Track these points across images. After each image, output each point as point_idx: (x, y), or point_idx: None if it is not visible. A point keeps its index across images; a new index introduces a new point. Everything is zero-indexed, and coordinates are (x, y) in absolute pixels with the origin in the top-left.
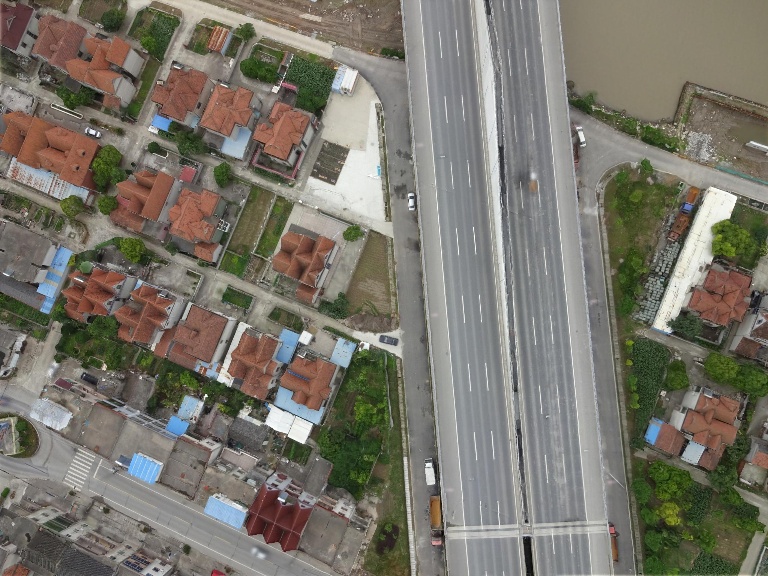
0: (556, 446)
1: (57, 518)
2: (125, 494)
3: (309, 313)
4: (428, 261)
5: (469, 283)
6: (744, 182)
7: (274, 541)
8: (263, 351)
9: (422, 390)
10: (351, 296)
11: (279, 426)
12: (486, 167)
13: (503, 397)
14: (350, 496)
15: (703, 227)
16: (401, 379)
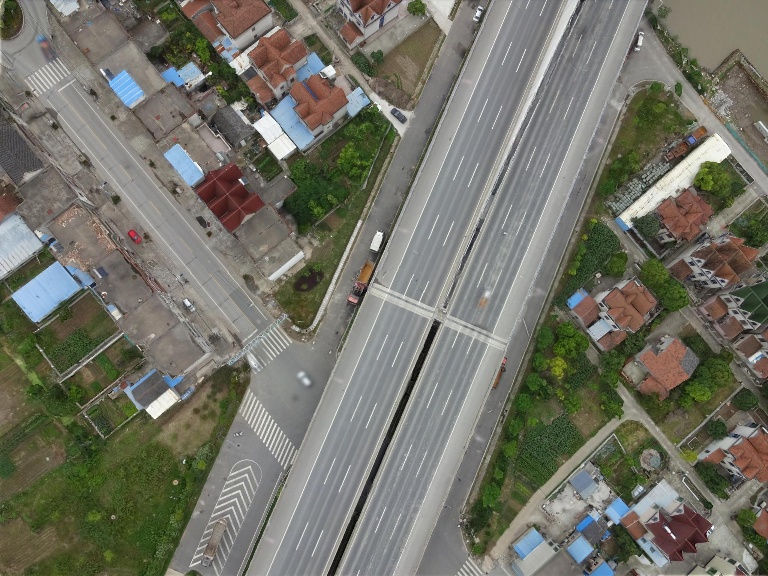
0: (500, 261)
1: (5, 101)
2: (82, 121)
3: (341, 56)
4: (474, 55)
5: (499, 92)
6: (740, 148)
7: (216, 213)
8: (291, 51)
9: (405, 172)
10: (386, 62)
11: (265, 132)
12: (561, 7)
13: (478, 199)
14: (295, 228)
15: (695, 160)
16: (392, 154)
